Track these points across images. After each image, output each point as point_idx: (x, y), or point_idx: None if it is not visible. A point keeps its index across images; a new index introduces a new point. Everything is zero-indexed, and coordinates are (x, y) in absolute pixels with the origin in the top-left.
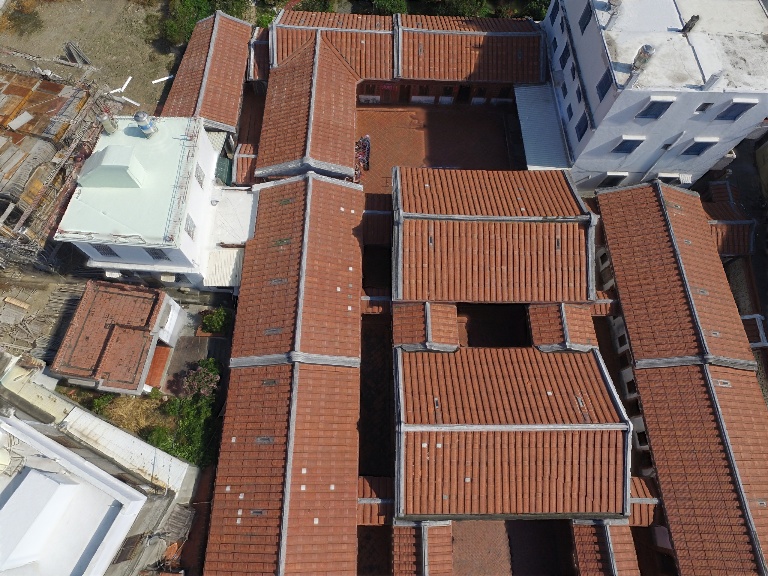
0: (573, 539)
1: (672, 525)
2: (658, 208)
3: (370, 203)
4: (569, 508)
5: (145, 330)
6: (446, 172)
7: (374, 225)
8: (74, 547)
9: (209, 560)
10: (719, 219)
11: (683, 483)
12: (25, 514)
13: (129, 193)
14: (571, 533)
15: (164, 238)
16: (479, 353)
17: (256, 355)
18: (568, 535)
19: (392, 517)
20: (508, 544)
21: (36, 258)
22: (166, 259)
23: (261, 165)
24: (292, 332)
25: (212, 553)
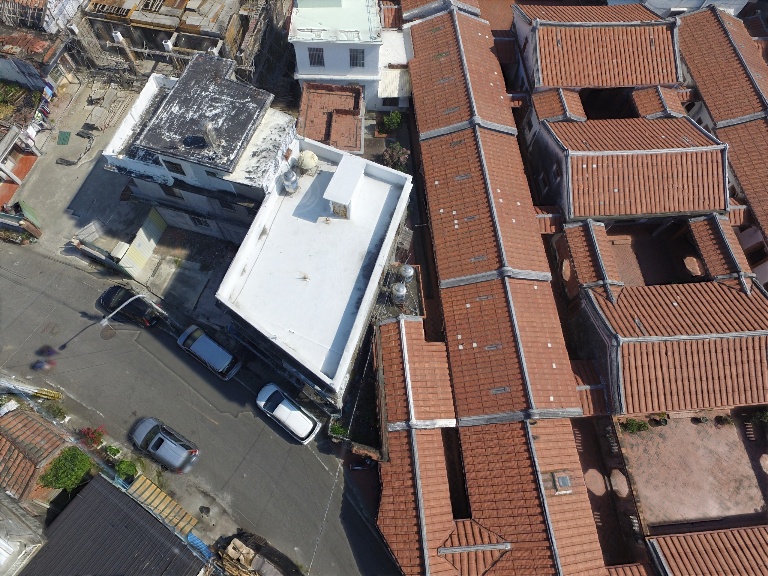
0: (691, 231)
1: (759, 217)
2: (717, 23)
3: (496, 34)
4: (687, 208)
5: (355, 114)
6: (553, 7)
7: (503, 48)
8: (373, 212)
9: (439, 254)
10: (759, 37)
11: (763, 191)
12: (352, 174)
13: (334, 11)
14: (689, 228)
15: (371, 38)
16: (603, 121)
17: (442, 127)
18: (678, 250)
19: (562, 224)
20: (636, 258)
21: (252, 75)
22: (360, 66)
23: (407, 9)
24: (469, 107)
25: (440, 249)
